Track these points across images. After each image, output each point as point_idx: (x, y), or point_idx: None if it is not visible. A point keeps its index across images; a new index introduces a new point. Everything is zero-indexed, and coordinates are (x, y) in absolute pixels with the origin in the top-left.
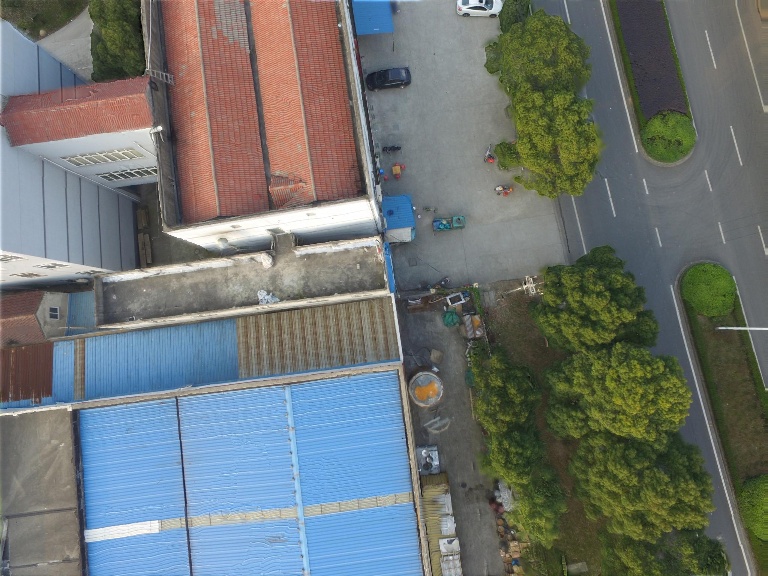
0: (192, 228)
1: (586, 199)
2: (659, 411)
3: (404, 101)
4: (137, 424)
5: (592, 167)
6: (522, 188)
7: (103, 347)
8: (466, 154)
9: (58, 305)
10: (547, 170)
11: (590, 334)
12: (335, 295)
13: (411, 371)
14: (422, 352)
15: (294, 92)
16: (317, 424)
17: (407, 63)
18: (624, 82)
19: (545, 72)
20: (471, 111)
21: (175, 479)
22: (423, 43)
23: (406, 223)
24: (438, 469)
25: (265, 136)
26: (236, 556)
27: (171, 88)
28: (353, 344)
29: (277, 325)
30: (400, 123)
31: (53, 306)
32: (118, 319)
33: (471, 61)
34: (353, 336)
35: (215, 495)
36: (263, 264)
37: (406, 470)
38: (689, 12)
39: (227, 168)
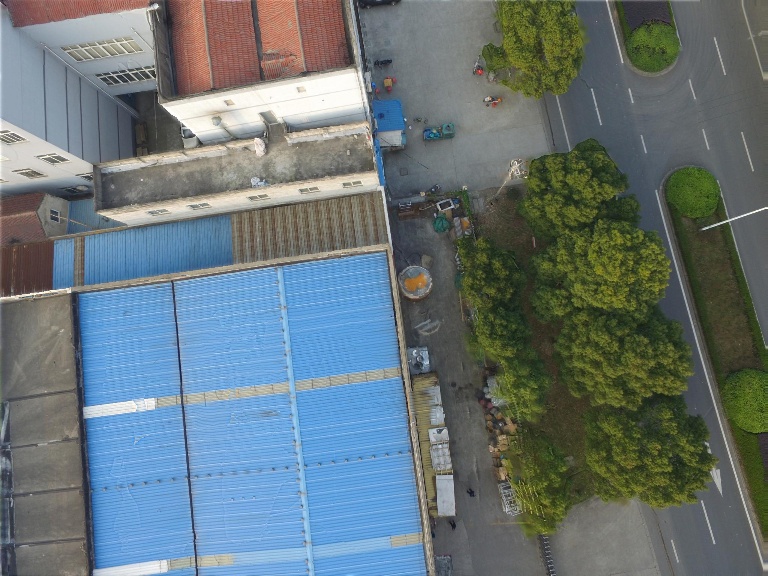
0: (187, 99)
1: (573, 108)
2: (639, 281)
3: (395, 18)
4: (134, 307)
5: (576, 63)
6: (510, 99)
7: (102, 244)
8: (456, 67)
9: (59, 209)
10: (533, 68)
11: (573, 211)
12: (326, 177)
13: (401, 265)
14: (413, 257)
15: None
16: (308, 303)
17: None
18: None
19: None
20: (461, 26)
21: (171, 359)
22: None
23: (396, 126)
24: (428, 369)
25: (257, 18)
26: None
27: None
28: (344, 236)
29: (271, 220)
30: (391, 39)
31: (54, 209)
32: (116, 207)
33: None
34: (344, 229)
35: (209, 373)
36: (256, 152)
37: (395, 346)
38: None
39: (220, 44)
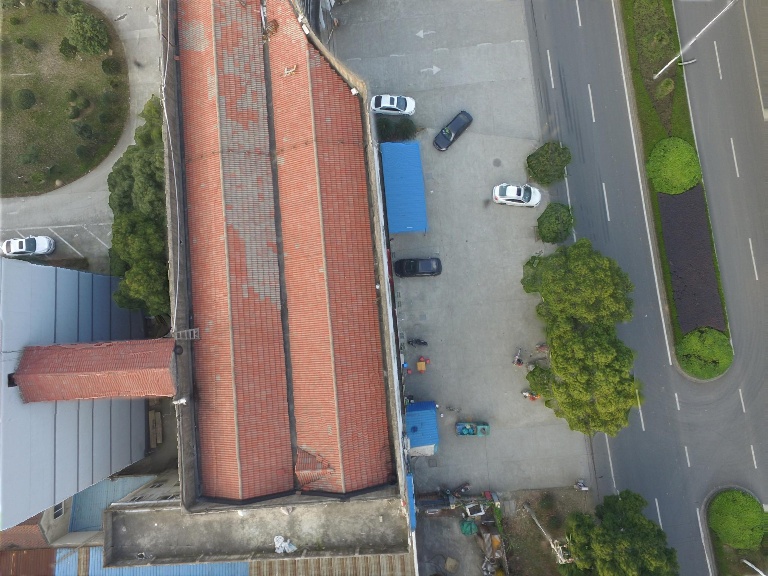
0: (212, 512)
1: None
2: None
3: (433, 290)
4: None
5: (628, 412)
6: None
7: None
8: (494, 352)
9: None
10: None
11: None
12: (356, 556)
13: None
14: (437, 559)
15: (327, 370)
16: None
17: (438, 249)
18: (662, 288)
19: (586, 316)
20: (502, 306)
21: None
22: (456, 229)
23: (430, 440)
24: None
25: (293, 402)
26: None
27: (196, 341)
28: None
29: None
30: (427, 313)
31: None
32: (127, 553)
33: (504, 252)
34: (370, 571)
35: None
36: None
37: None
38: (733, 219)
39: (252, 444)
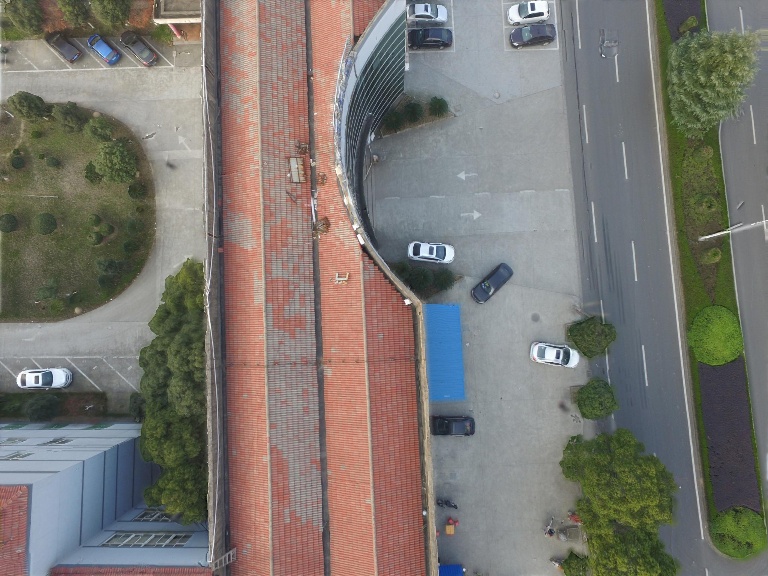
0: None
1: None
2: None
3: (465, 448)
4: None
5: None
6: None
7: None
8: (524, 516)
9: None
10: None
11: None
12: None
13: None
14: None
15: None
16: None
17: (472, 405)
18: (697, 459)
19: (629, 521)
20: (534, 468)
21: None
22: (491, 385)
23: None
24: None
25: None
26: None
27: None
28: None
29: None
30: (458, 472)
31: None
32: None
33: (539, 412)
34: None
35: None
36: None
37: None
38: None
39: None
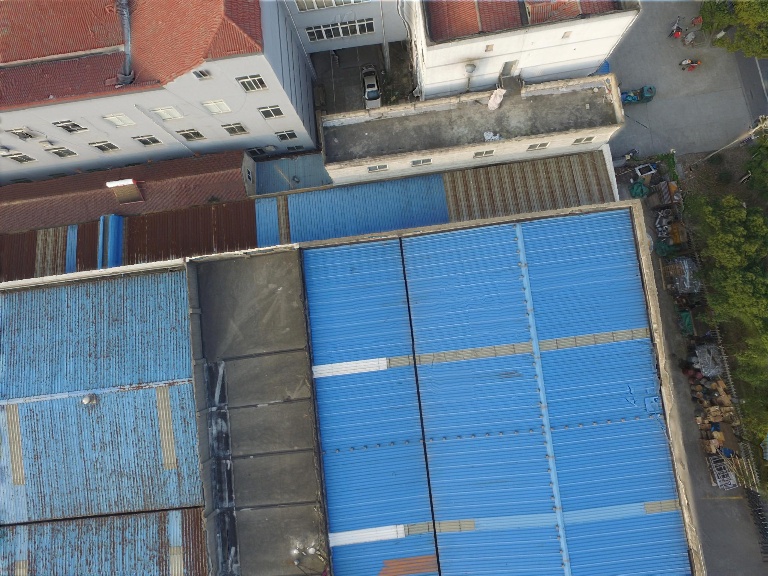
0: (456, 42)
1: None
2: None
3: None
4: (361, 264)
5: None
6: (707, 63)
7: (307, 203)
8: (649, 30)
9: (251, 169)
10: (761, 25)
11: None
12: (571, 130)
13: None
14: None
15: None
16: (549, 261)
17: None
18: None
19: None
20: None
21: (402, 318)
22: None
23: None
24: None
25: None
26: (463, 396)
27: None
28: (566, 196)
29: (485, 179)
30: None
31: (248, 168)
32: None
33: None
34: (566, 188)
35: (445, 332)
36: (489, 106)
37: (642, 306)
38: None
39: None
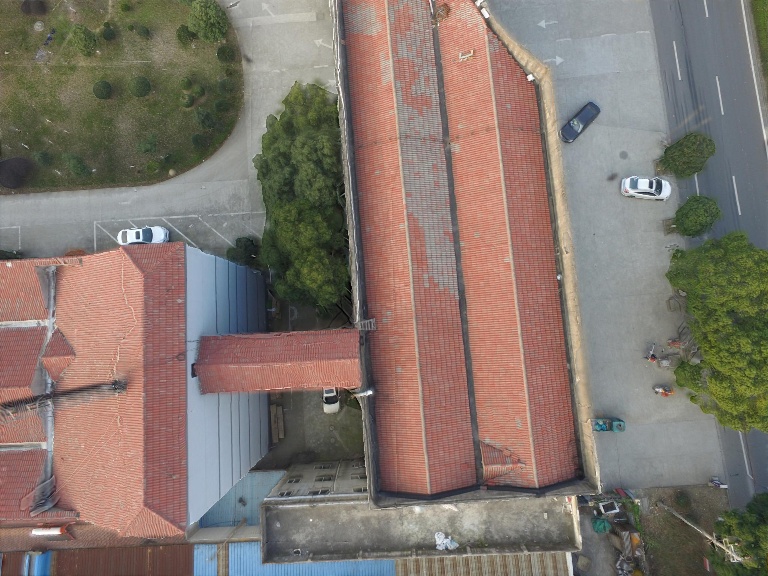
0: (401, 507)
1: None
2: None
3: None
4: None
5: None
6: (681, 388)
7: (249, 556)
8: (624, 347)
9: None
10: None
11: None
12: (525, 553)
13: None
14: None
15: (516, 362)
16: None
17: (565, 242)
18: None
19: (748, 310)
20: (631, 300)
21: None
22: (583, 222)
23: None
24: None
25: (473, 395)
26: None
27: (371, 332)
28: None
29: None
30: None
31: None
32: (282, 550)
33: (633, 246)
34: (521, 569)
35: None
36: None
37: None
38: None
39: (438, 437)
